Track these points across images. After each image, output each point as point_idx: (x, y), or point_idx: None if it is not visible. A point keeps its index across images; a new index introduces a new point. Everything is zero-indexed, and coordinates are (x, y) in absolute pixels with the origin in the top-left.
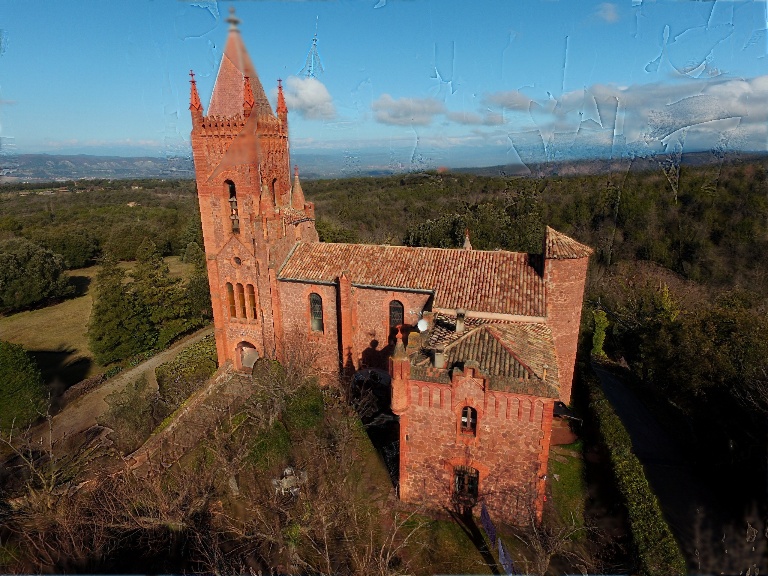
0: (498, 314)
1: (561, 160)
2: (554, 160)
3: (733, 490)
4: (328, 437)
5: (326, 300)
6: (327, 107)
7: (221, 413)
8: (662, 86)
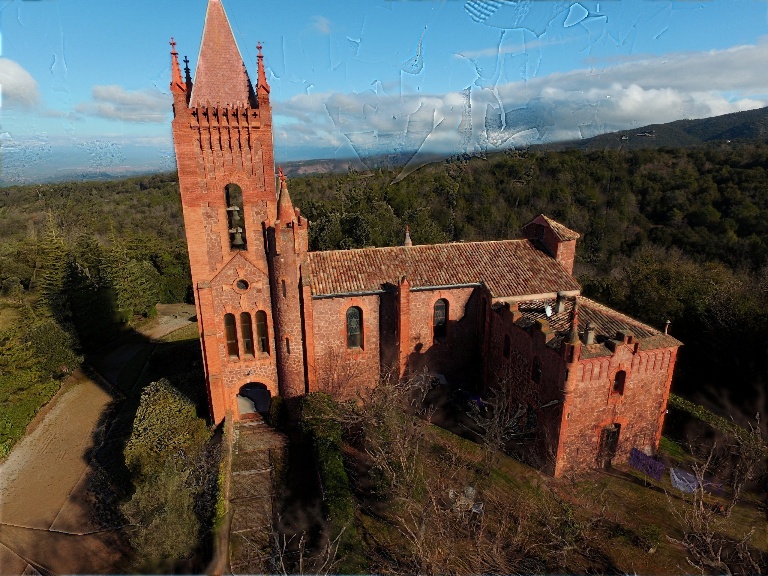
0: (546, 294)
1: (394, 159)
2: (388, 159)
3: (692, 388)
4: (429, 451)
5: (368, 311)
6: (130, 96)
7: (268, 474)
8: None
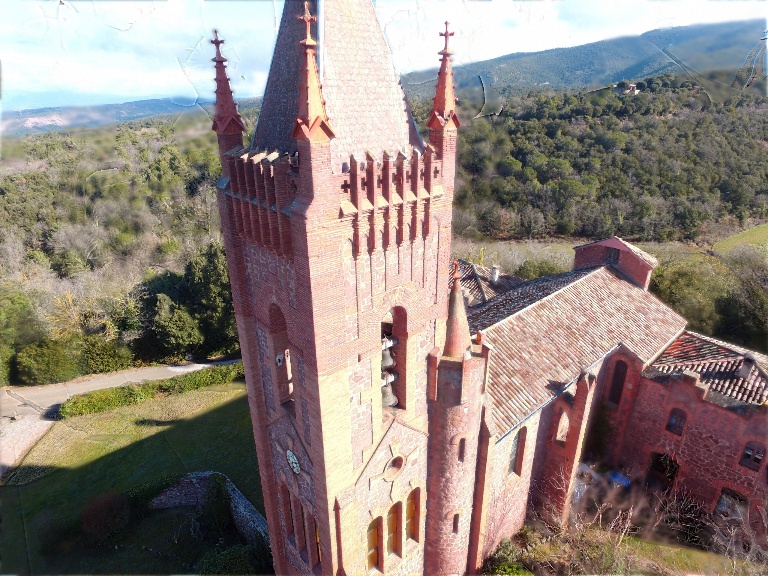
0: None
1: None
2: None
3: None
4: None
5: (531, 427)
6: None
7: None
8: (412, 67)
